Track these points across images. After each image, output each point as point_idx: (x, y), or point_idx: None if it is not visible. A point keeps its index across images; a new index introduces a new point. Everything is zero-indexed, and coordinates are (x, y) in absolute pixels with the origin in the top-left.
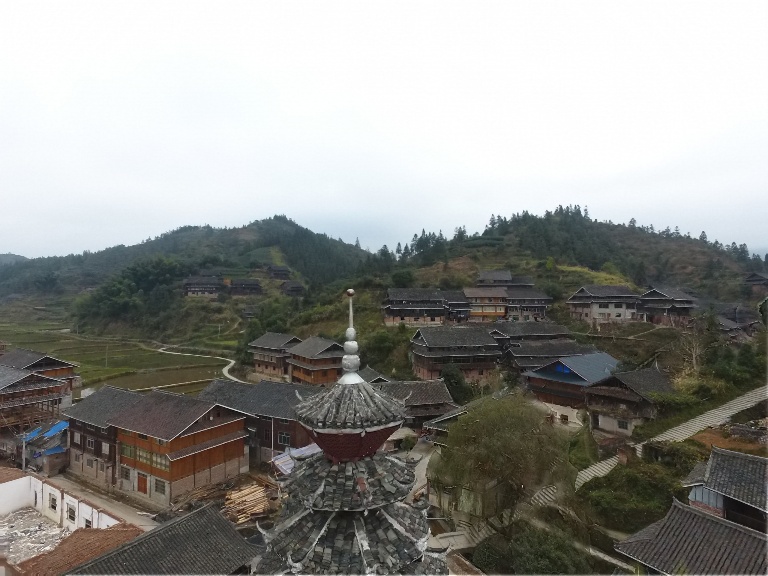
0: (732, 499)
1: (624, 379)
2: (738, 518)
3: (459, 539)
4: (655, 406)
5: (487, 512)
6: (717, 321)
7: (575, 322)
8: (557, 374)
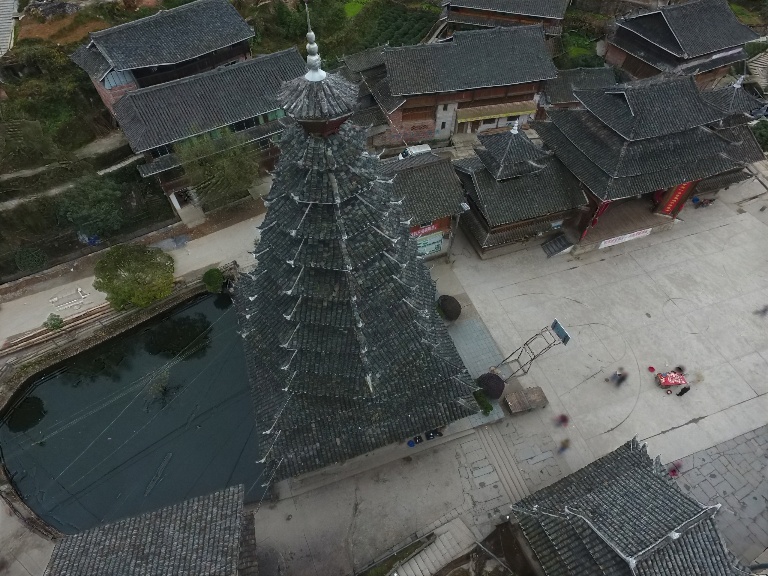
0: (138, 69)
1: None
2: (143, 81)
3: None
4: None
5: None
6: None
7: None
8: None
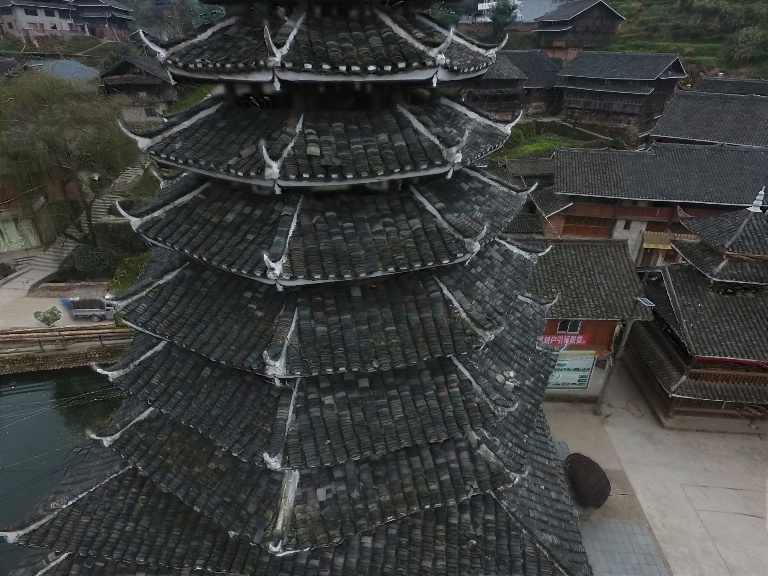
0: None
1: (136, 62)
2: None
3: (30, 274)
4: (174, 87)
5: (46, 238)
6: (188, 7)
7: None
8: None
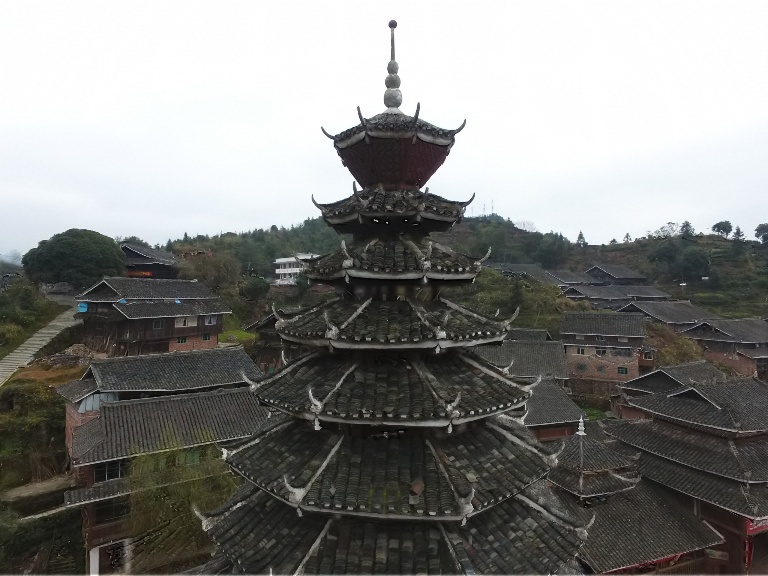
0: (127, 392)
1: None
2: None
3: None
4: None
5: None
6: None
7: None
8: None
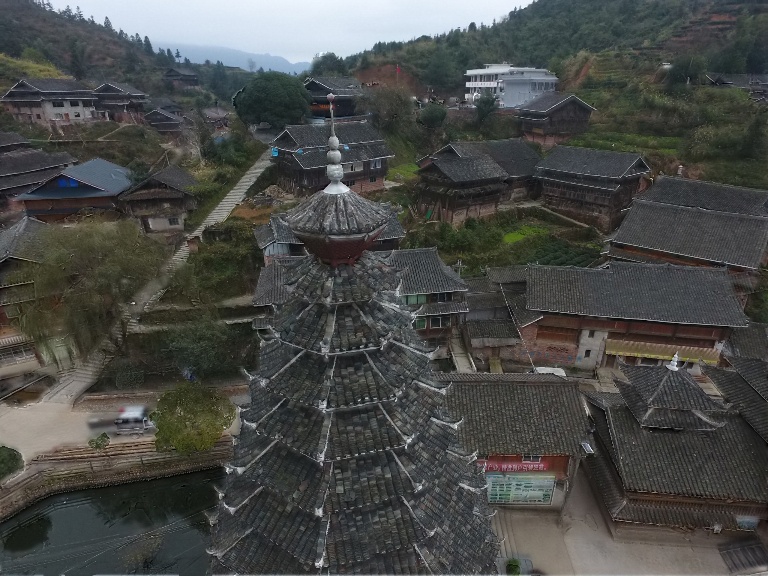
0: (294, 244)
1: (162, 179)
2: (296, 255)
3: (73, 387)
4: (195, 198)
5: (85, 349)
6: (205, 115)
7: (25, 127)
8: (64, 190)
